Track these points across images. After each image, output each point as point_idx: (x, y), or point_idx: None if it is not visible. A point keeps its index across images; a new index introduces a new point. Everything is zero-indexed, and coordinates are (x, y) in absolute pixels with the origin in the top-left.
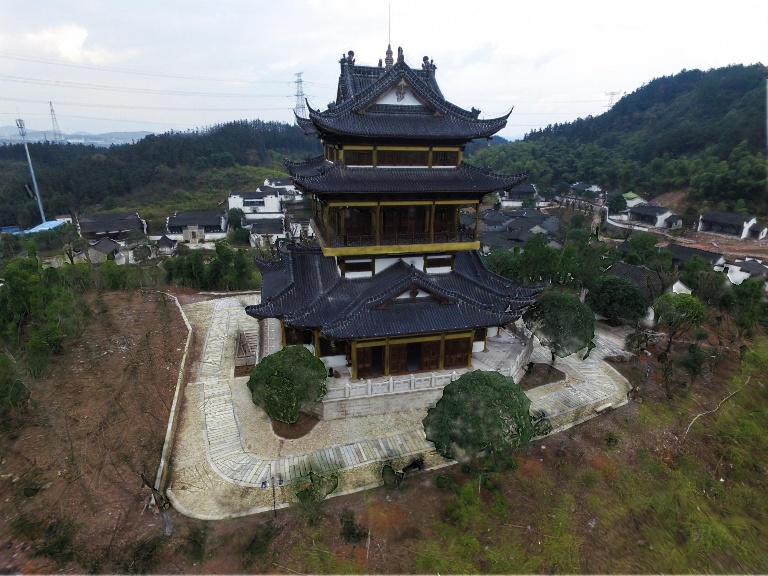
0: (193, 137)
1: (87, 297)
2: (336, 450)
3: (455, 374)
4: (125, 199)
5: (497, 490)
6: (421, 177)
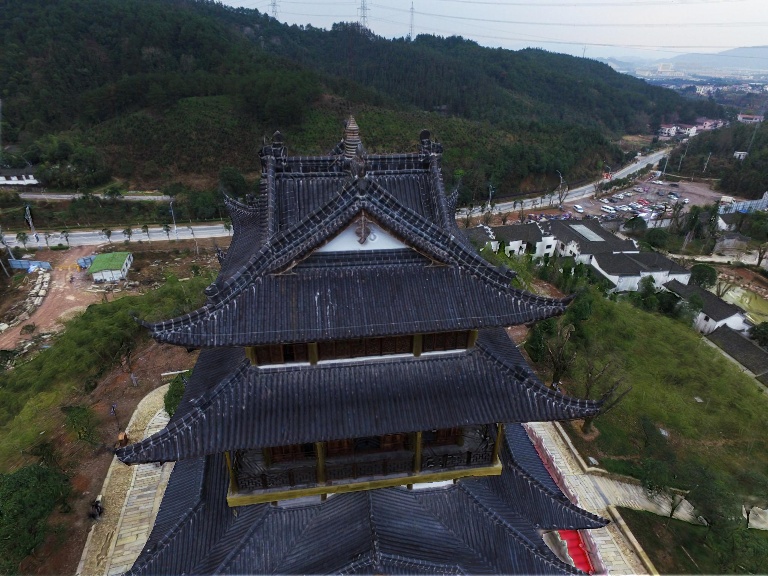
0: None
1: None
2: None
3: None
4: None
5: None
6: None
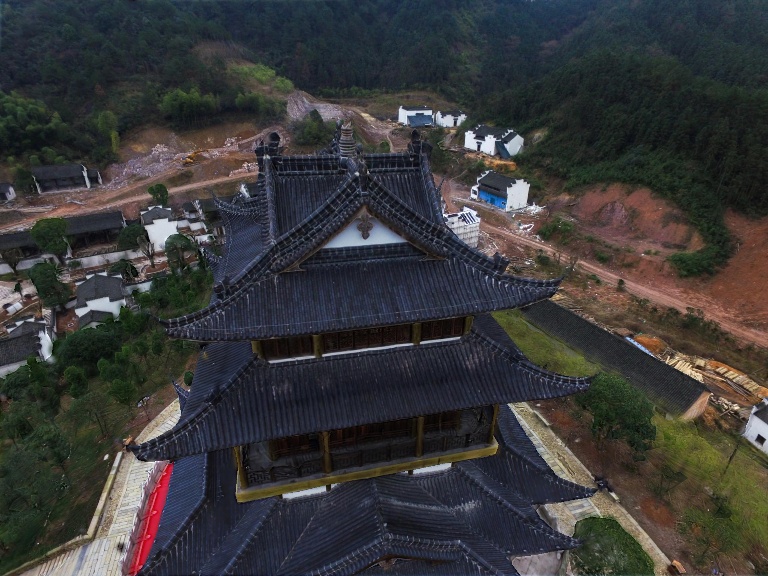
0: None
1: None
2: None
3: None
4: None
5: None
6: None
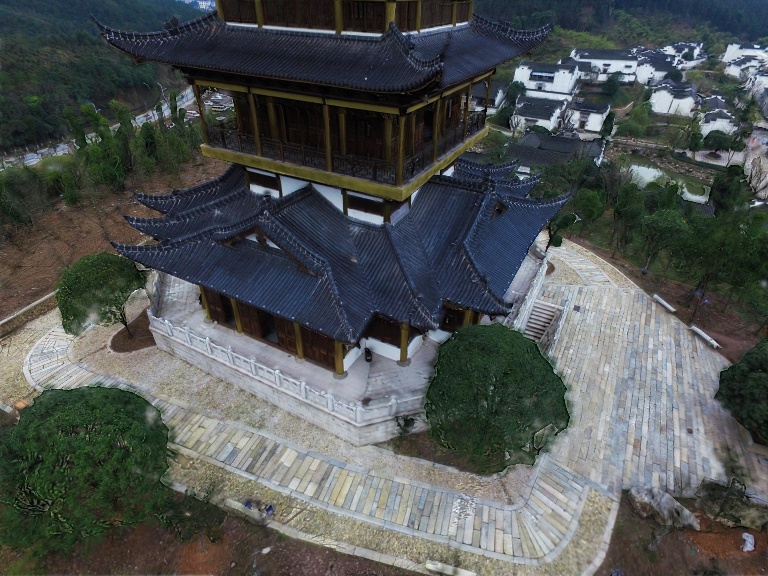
0: None
1: None
2: (115, 384)
3: (278, 374)
4: None
5: (120, 554)
6: (308, 50)
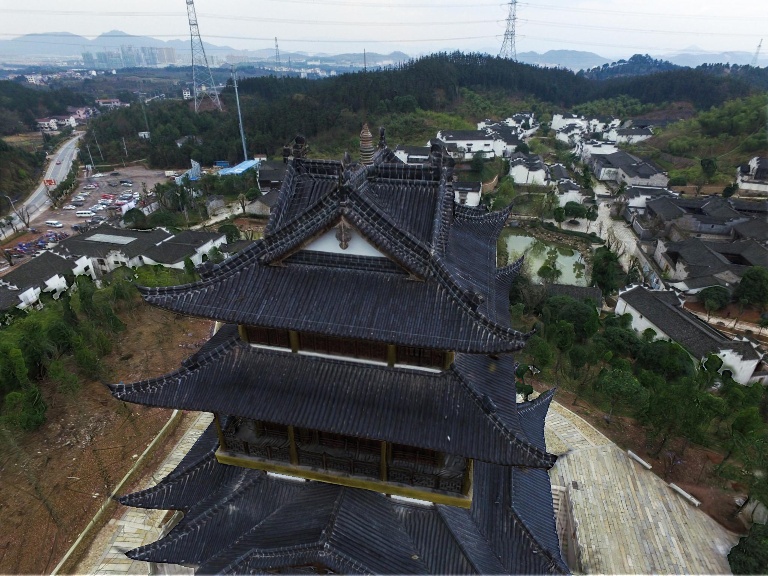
0: (384, 76)
1: (142, 321)
2: None
3: None
4: (309, 142)
5: None
6: (363, 388)
